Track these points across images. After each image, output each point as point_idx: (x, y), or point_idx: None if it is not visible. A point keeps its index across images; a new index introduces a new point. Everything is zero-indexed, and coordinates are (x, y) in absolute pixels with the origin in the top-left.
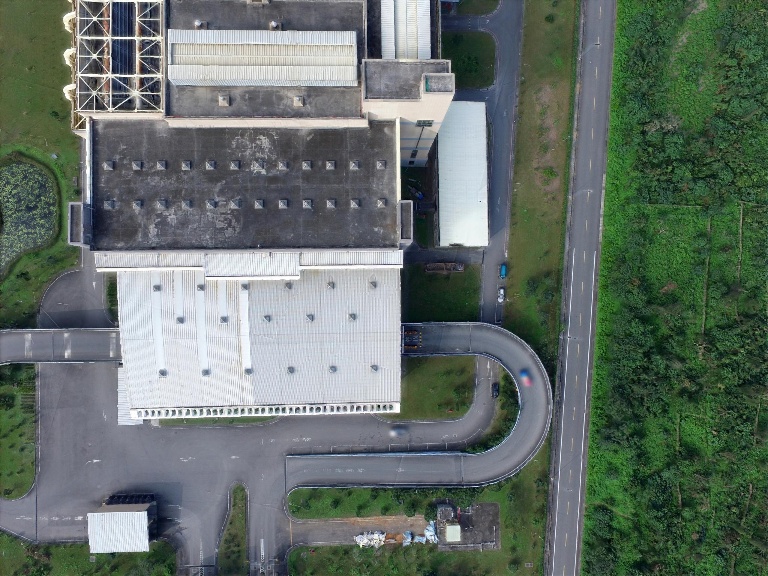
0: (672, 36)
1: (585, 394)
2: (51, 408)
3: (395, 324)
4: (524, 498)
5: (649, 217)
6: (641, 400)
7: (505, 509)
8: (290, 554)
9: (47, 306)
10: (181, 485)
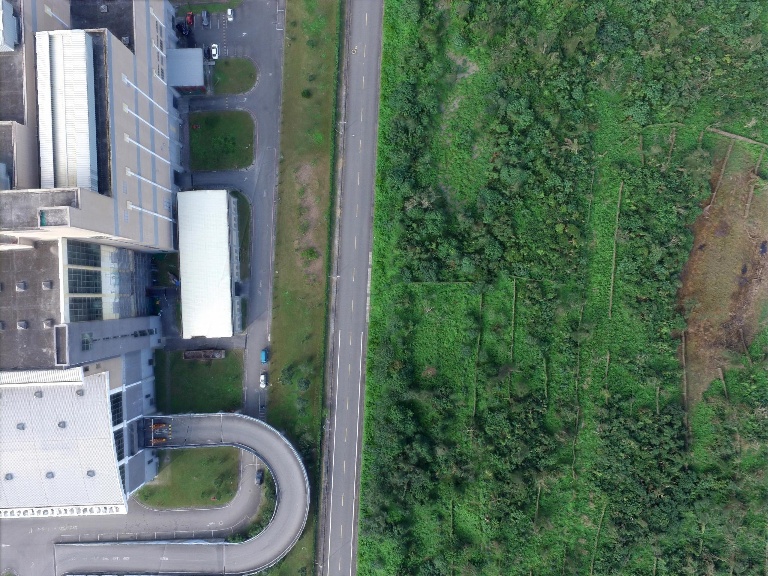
0: (437, 104)
1: (354, 479)
2: None
3: (106, 430)
4: None
5: (417, 295)
6: (408, 487)
7: None
8: None
9: None
10: None
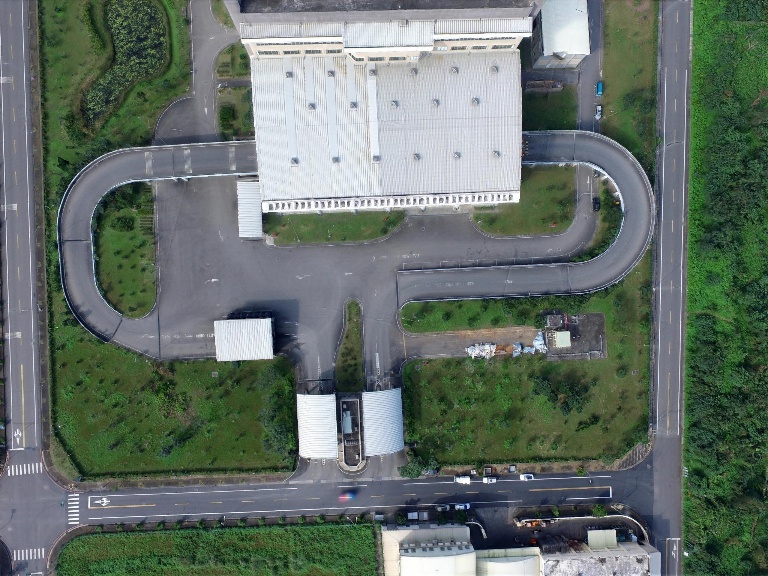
0: None
1: (682, 207)
2: (169, 230)
3: (516, 108)
4: (628, 308)
5: (737, 35)
6: (738, 209)
7: (610, 319)
8: (405, 367)
9: (161, 132)
10: (297, 302)
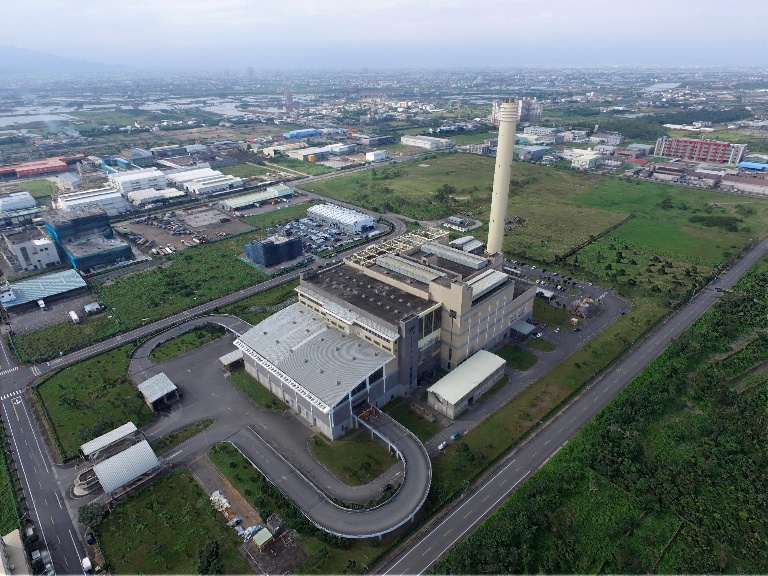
0: (662, 409)
1: (448, 547)
2: (207, 347)
3: (368, 372)
4: (330, 574)
5: (588, 478)
6: None
7: None
8: (179, 469)
9: None
10: (196, 401)
